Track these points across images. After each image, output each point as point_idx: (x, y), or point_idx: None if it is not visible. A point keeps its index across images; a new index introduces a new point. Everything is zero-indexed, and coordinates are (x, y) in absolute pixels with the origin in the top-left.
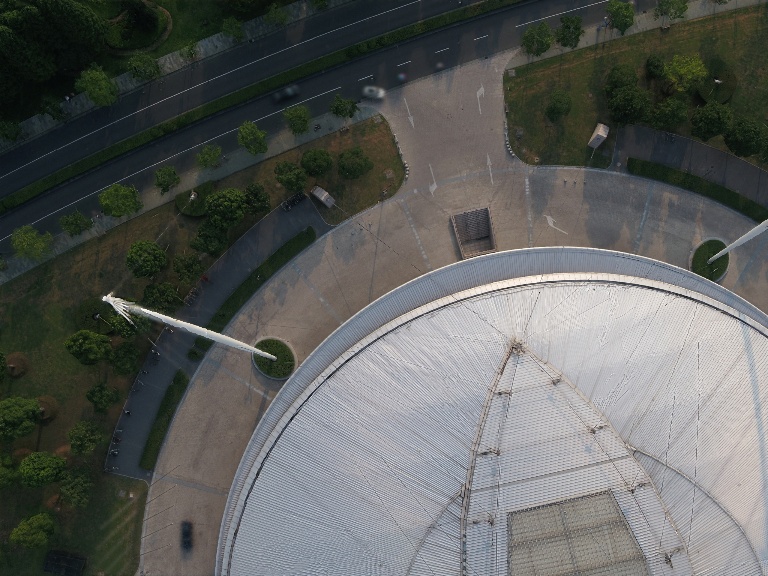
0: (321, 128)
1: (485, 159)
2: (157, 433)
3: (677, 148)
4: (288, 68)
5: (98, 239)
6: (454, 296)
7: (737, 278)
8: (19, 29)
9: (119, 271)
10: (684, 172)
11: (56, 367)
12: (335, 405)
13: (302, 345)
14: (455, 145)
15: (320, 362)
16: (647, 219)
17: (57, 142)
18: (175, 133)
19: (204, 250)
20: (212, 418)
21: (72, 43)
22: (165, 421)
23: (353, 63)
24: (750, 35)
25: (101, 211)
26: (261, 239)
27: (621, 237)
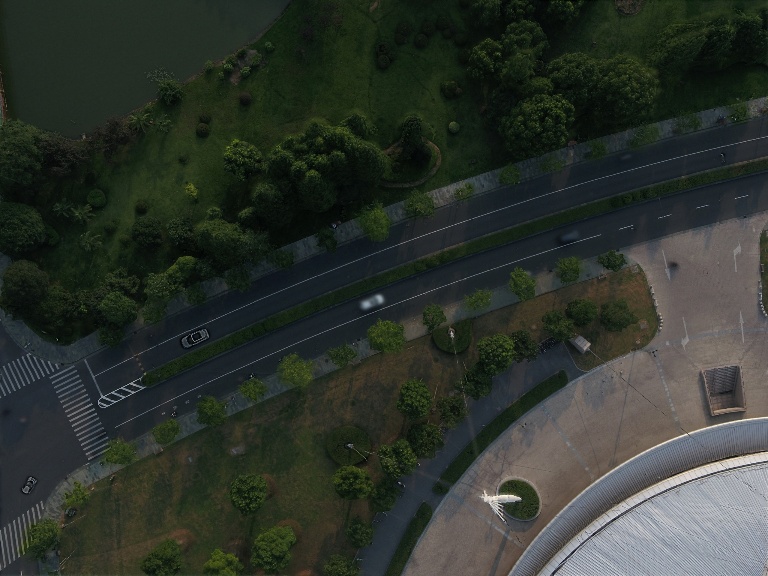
0: (579, 274)
1: (738, 317)
2: (397, 565)
3: None
4: (551, 212)
5: (352, 367)
6: (723, 464)
7: None
8: (325, 173)
9: (371, 401)
10: None
11: (302, 492)
12: (602, 565)
13: (546, 488)
14: (709, 301)
15: (577, 514)
16: None
17: (319, 267)
18: (436, 268)
19: (473, 395)
20: (451, 553)
21: (356, 179)
22: (406, 554)
23: (615, 212)
24: None
25: (357, 339)
26: (513, 379)
27: None
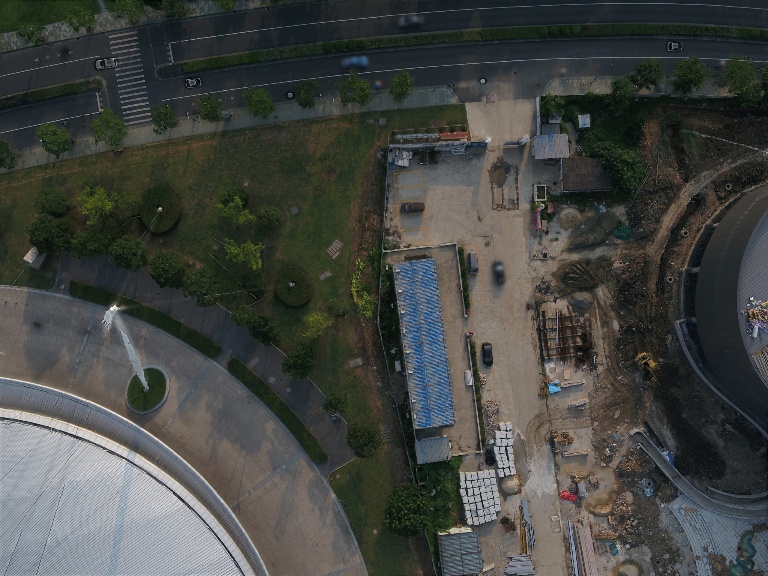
0: None
1: None
2: None
3: (123, 273)
4: None
5: None
6: None
7: (176, 407)
8: None
9: None
10: (127, 298)
11: None
12: None
13: None
14: None
15: None
16: (88, 343)
17: None
18: None
19: None
20: None
21: None
22: None
23: None
24: (201, 163)
25: None
26: None
27: (60, 361)
